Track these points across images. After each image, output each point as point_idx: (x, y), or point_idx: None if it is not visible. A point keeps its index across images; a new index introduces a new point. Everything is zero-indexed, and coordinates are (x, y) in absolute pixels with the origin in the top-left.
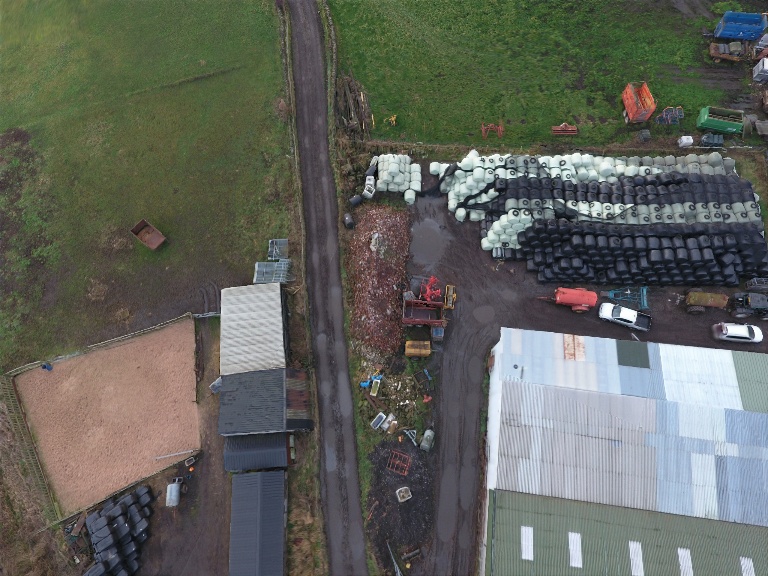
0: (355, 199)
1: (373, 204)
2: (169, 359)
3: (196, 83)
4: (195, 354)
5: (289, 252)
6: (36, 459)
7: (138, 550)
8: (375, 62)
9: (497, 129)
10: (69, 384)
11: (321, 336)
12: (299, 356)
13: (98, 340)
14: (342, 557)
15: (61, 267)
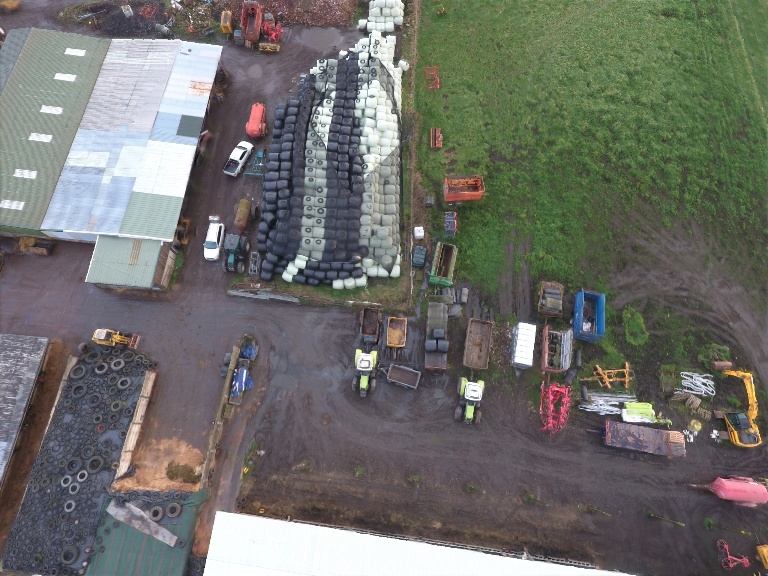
0: None
1: (356, 1)
2: None
3: None
4: None
5: None
6: None
7: None
8: None
9: None
10: None
11: None
12: None
13: None
14: None
15: None
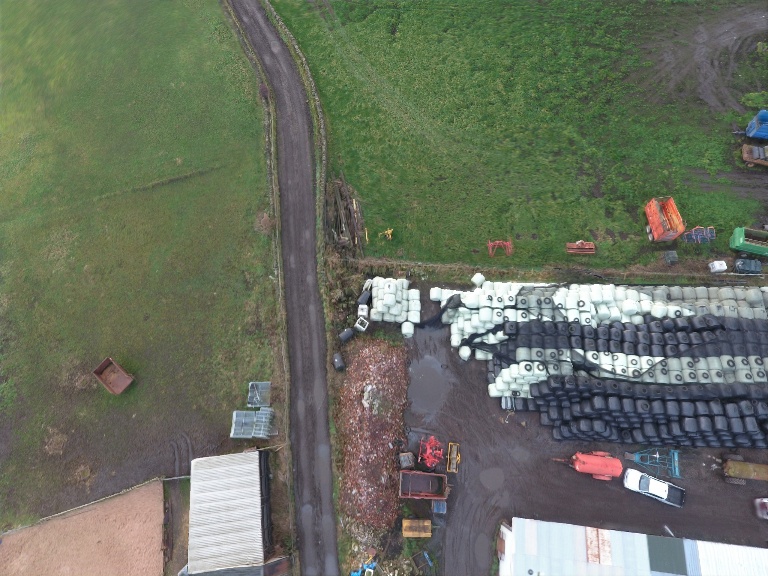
0: (346, 334)
1: (366, 338)
2: (134, 532)
3: (171, 185)
4: (163, 527)
5: (271, 398)
6: None
7: None
8: (369, 162)
9: (505, 246)
10: (19, 563)
11: (306, 508)
12: (281, 533)
13: (54, 506)
14: None
15: (16, 410)
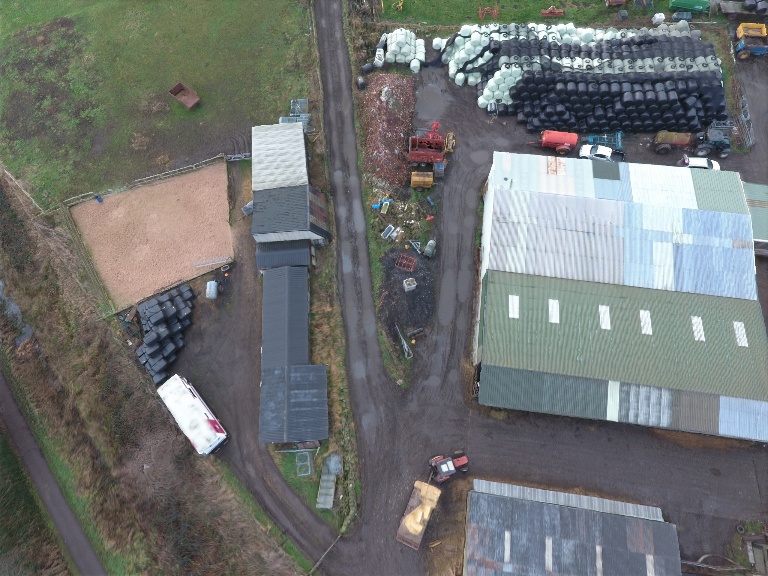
0: (367, 66)
1: (382, 72)
2: (205, 193)
3: None
4: (228, 188)
5: (309, 109)
6: (92, 267)
7: (182, 333)
8: None
9: (492, 12)
10: (118, 212)
11: (338, 172)
12: None
13: None
14: (357, 335)
15: (107, 125)
